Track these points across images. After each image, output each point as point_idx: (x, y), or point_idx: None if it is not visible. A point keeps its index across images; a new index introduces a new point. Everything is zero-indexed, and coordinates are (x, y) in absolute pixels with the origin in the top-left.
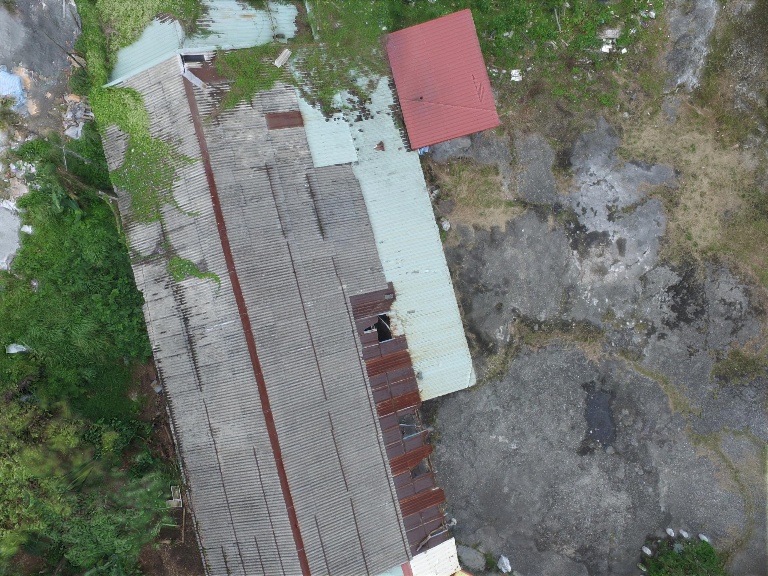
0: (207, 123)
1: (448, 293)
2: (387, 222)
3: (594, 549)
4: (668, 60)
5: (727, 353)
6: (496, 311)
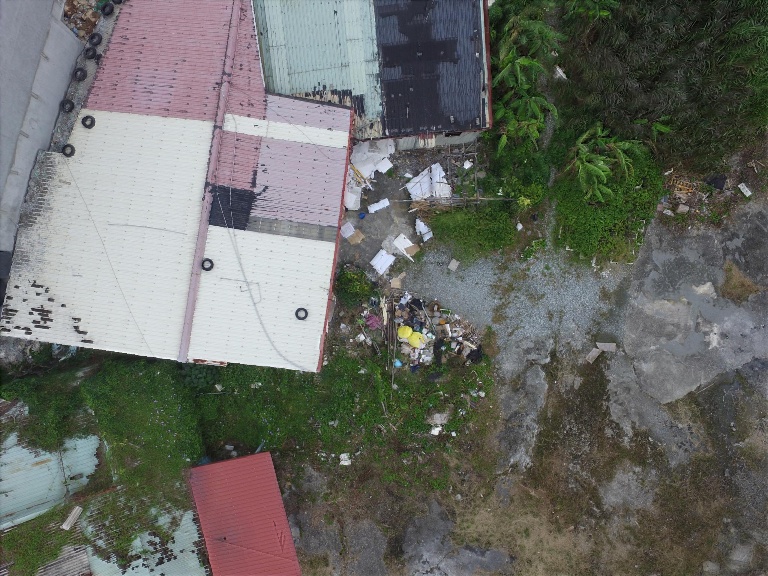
0: None
1: None
2: None
3: None
4: (500, 439)
5: None
6: None
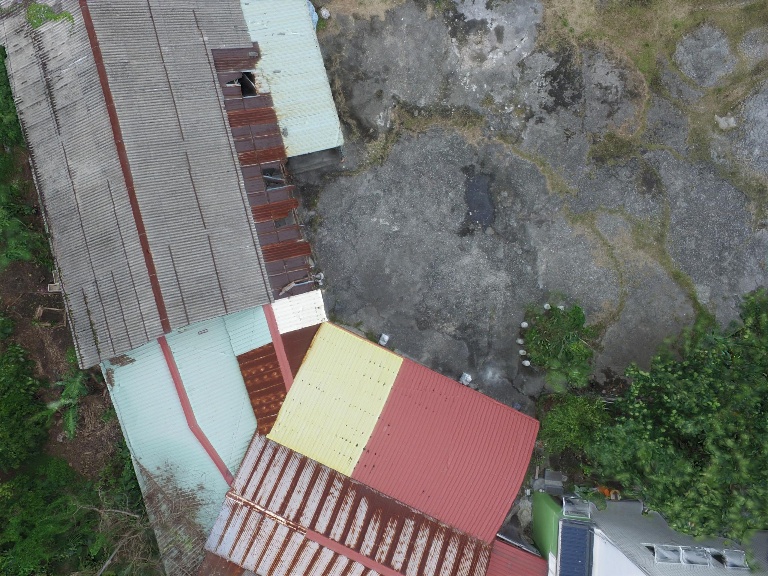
0: None
1: (315, 56)
2: None
3: (474, 327)
4: None
5: (604, 135)
6: (376, 98)
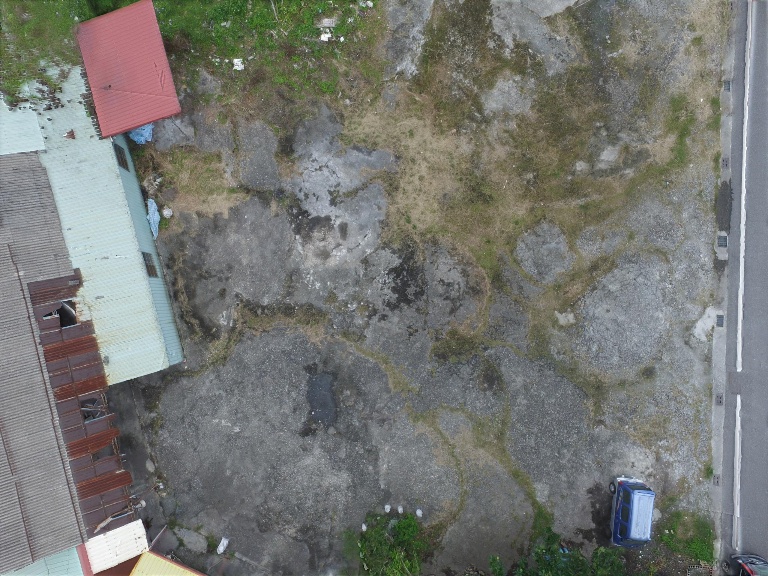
0: None
1: (140, 278)
2: (76, 209)
3: (315, 528)
4: (387, 48)
5: (446, 332)
6: (219, 296)
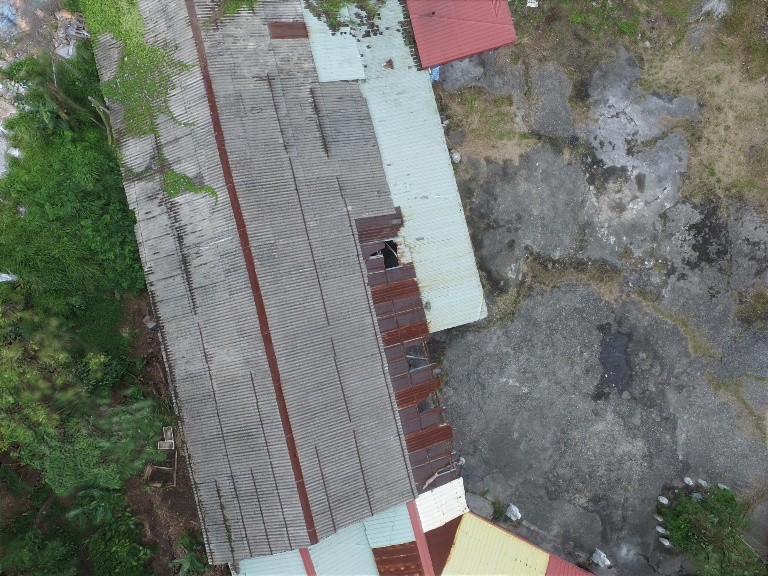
0: (205, 27)
1: (459, 220)
2: (395, 144)
3: (608, 498)
4: None
5: (750, 295)
6: (508, 248)
